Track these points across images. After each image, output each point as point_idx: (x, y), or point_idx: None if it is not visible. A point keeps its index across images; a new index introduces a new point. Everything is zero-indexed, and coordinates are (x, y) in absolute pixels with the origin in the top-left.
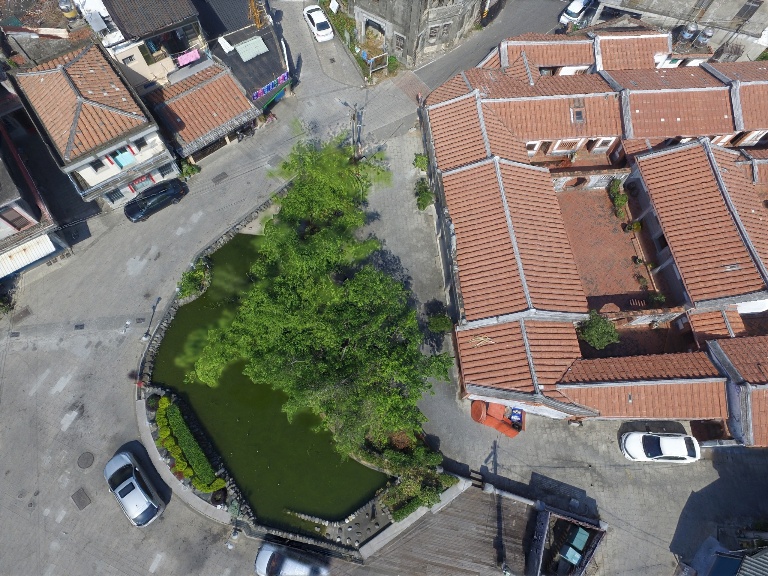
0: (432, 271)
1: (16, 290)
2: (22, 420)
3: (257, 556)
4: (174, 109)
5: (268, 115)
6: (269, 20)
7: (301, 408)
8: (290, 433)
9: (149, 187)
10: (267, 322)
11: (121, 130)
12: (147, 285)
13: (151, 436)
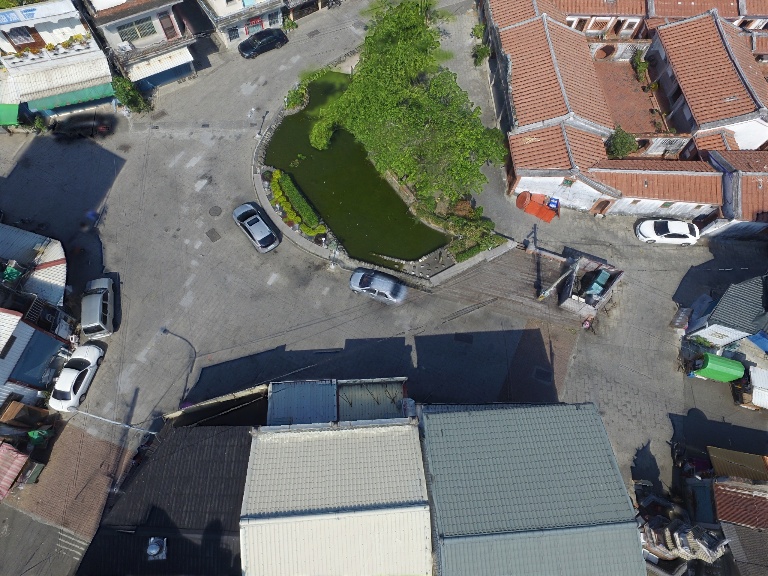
0: (486, 109)
1: (154, 98)
2: (165, 182)
3: (351, 276)
4: None
5: None
6: None
7: (382, 190)
8: (374, 206)
9: (259, 31)
10: (370, 95)
11: None
12: (257, 102)
13: (266, 197)
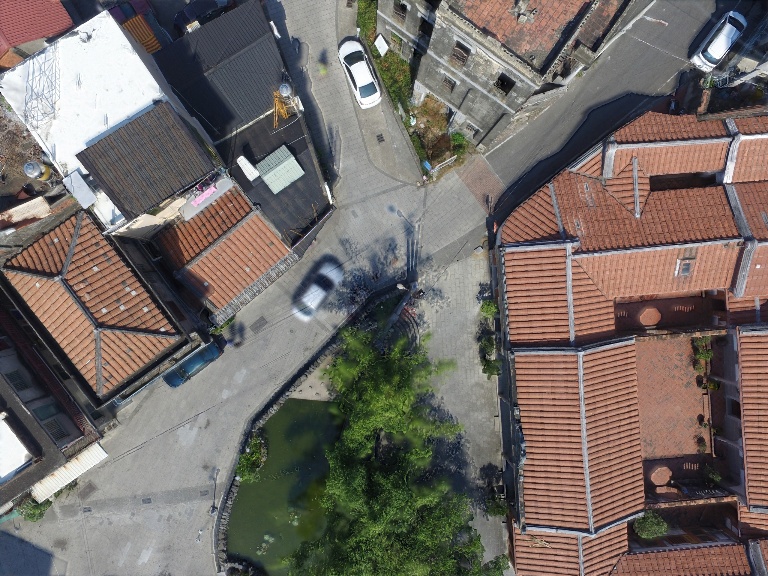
0: (490, 433)
1: None
2: None
3: None
4: (198, 272)
5: None
6: (299, 108)
7: None
8: None
9: None
10: None
11: (152, 354)
12: (203, 456)
13: None
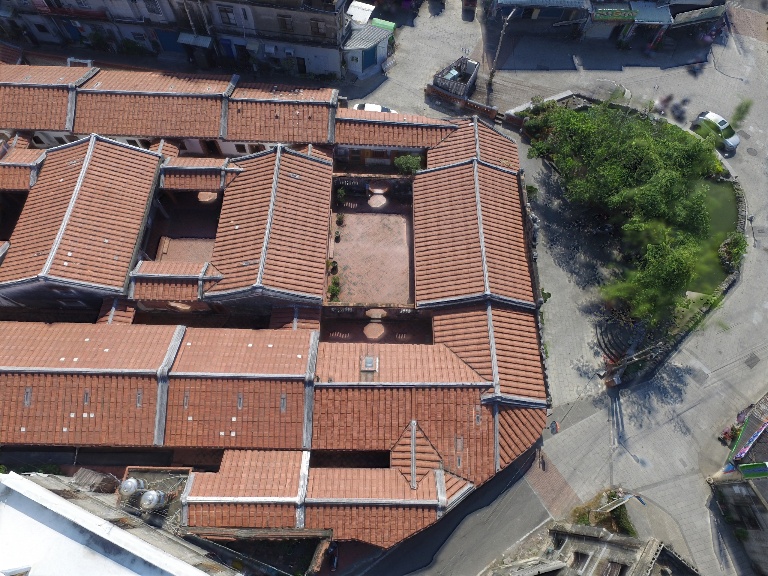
0: None
1: None
2: None
3: None
4: None
5: (732, 437)
6: None
7: None
8: None
9: None
10: None
11: None
12: None
13: None
